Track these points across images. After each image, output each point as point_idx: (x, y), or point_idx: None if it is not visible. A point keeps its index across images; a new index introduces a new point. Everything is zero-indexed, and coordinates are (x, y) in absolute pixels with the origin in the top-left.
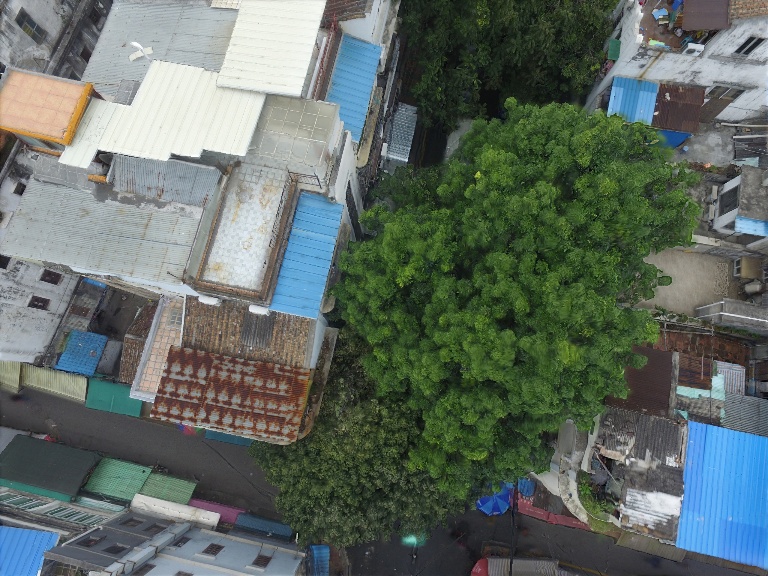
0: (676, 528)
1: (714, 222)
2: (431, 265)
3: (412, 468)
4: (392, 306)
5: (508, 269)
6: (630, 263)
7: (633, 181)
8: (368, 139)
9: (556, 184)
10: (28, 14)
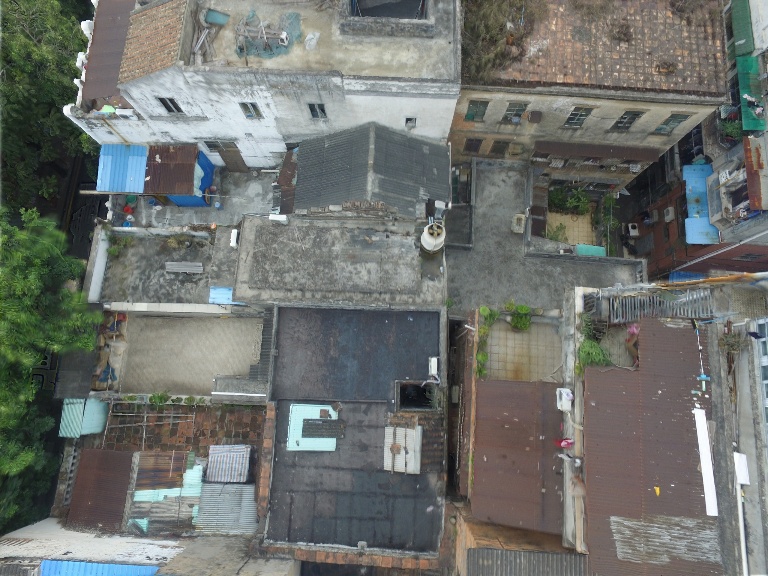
0: None
1: None
2: None
3: None
4: None
5: None
6: None
7: None
8: None
9: None
10: None
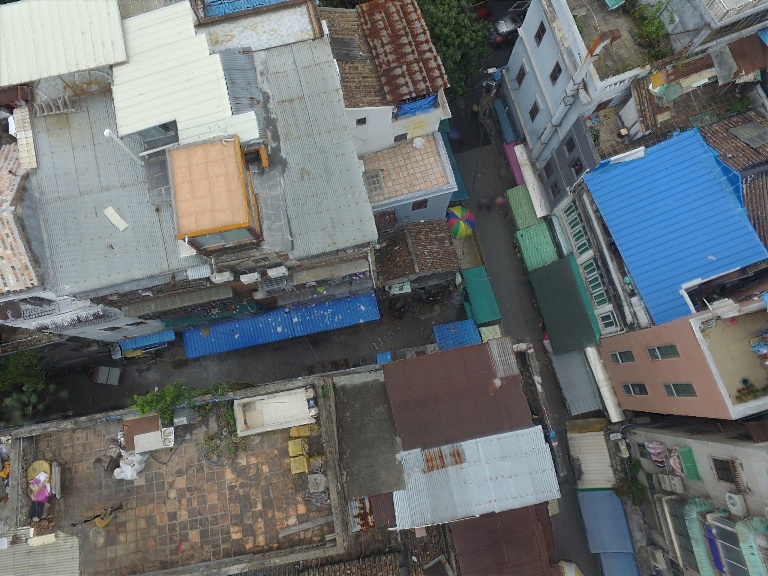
0: None
1: None
2: None
3: None
4: None
5: None
6: None
7: None
8: None
9: None
10: None
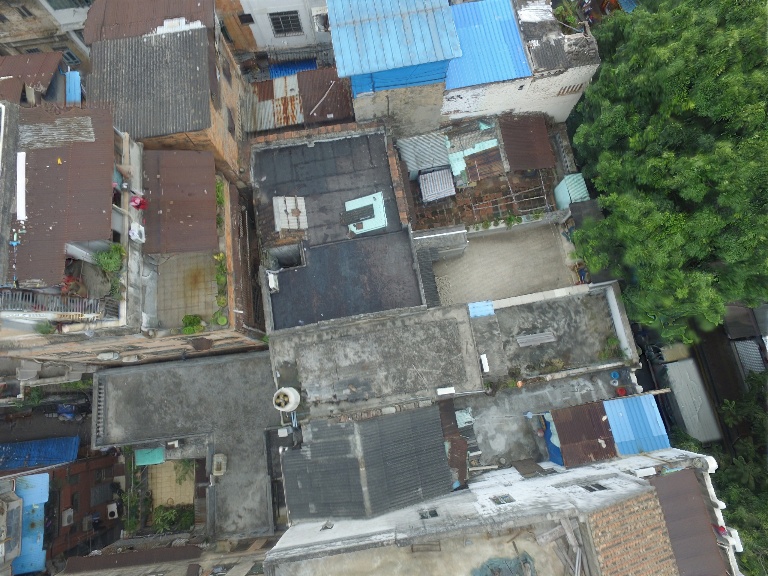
0: (516, 4)
1: None
2: None
3: None
4: None
5: None
6: None
7: (765, 155)
8: None
9: None
10: None
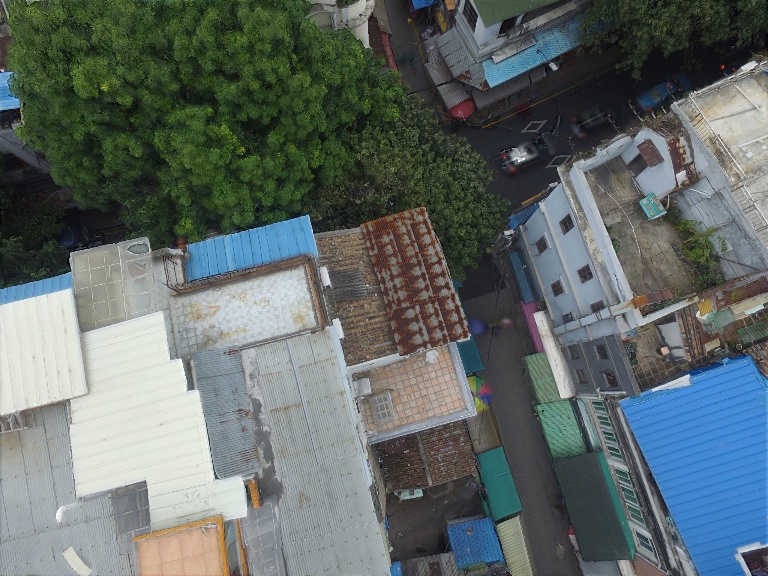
0: None
1: None
2: None
3: (397, 114)
4: None
5: None
6: None
7: None
8: None
9: None
10: None
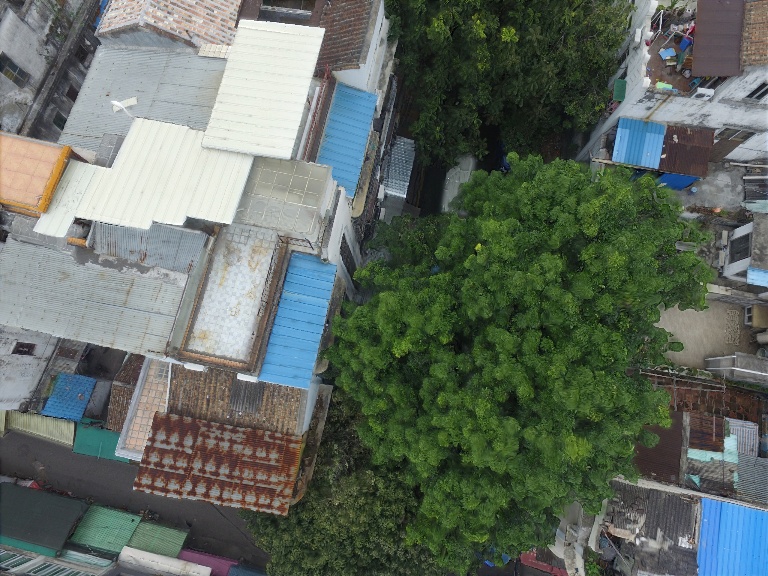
0: None
1: (724, 269)
2: (429, 335)
3: (409, 544)
4: (388, 374)
5: (511, 348)
6: (639, 328)
7: (644, 253)
8: (364, 187)
9: (561, 250)
10: (9, 58)
